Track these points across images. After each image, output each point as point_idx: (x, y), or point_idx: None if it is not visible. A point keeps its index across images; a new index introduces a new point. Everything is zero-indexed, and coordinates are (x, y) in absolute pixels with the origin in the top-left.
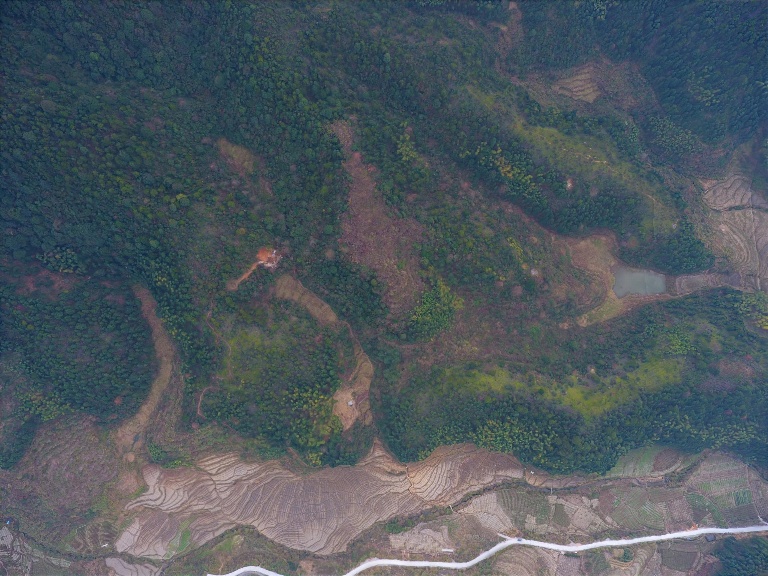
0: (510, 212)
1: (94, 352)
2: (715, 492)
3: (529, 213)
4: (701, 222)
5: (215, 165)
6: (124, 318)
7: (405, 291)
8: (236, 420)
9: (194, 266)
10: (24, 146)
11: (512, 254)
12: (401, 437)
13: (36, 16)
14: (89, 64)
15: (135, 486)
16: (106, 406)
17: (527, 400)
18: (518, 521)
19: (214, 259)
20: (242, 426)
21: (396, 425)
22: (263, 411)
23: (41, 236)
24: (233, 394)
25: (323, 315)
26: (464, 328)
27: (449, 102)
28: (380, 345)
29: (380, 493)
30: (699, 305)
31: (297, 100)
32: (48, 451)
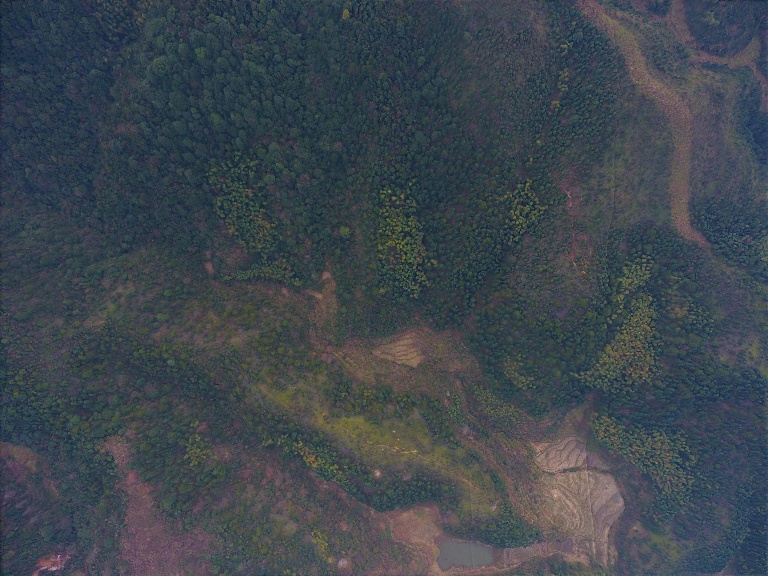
0: (325, 488)
1: None
2: None
3: None
4: (529, 492)
5: None
6: None
7: None
8: None
9: None
10: None
11: (314, 551)
12: None
13: None
14: None
15: None
16: None
17: None
18: None
19: None
20: None
21: None
22: None
23: None
24: None
25: None
26: None
27: (245, 396)
28: None
29: None
30: None
31: (67, 419)
32: None
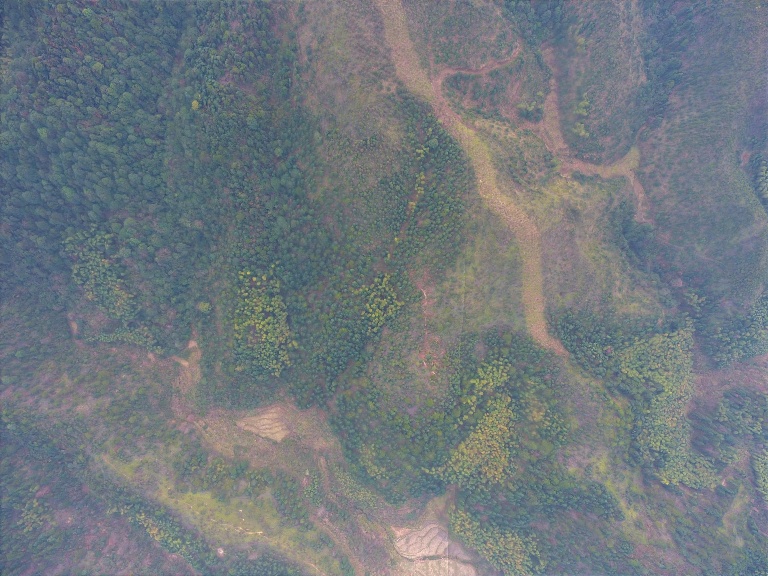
0: (173, 558)
1: None
2: None
3: None
4: None
5: None
6: None
7: None
8: None
9: None
10: None
11: None
12: None
13: None
14: None
15: None
16: None
17: None
18: None
19: None
20: None
21: None
22: None
23: None
24: None
25: None
26: None
27: None
28: None
29: None
30: None
31: None
32: None
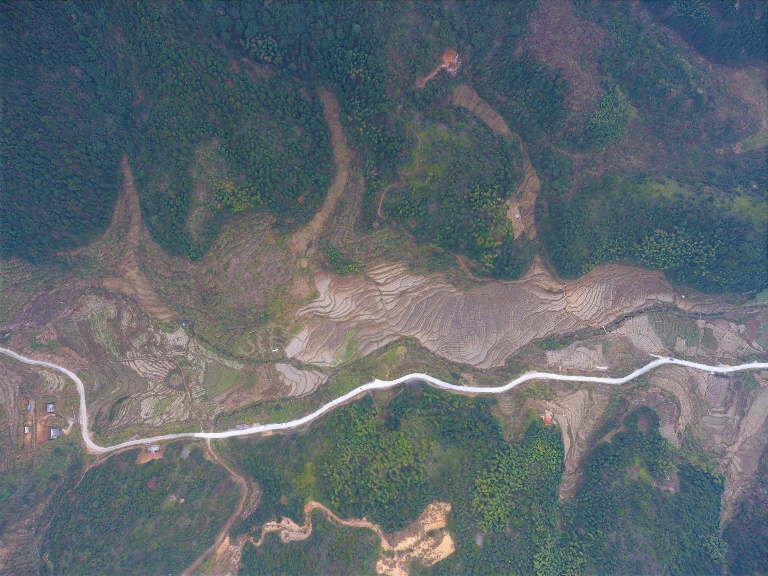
0: (671, 38)
1: (288, 142)
2: None
3: (690, 39)
4: None
5: None
6: (311, 116)
7: (586, 93)
8: (412, 223)
9: (391, 56)
10: None
11: (683, 68)
12: (569, 246)
13: None
14: None
15: (307, 292)
16: (289, 205)
17: (696, 207)
18: (669, 343)
19: (411, 49)
20: (419, 228)
21: (566, 232)
22: (445, 208)
23: (246, 20)
24: (418, 190)
25: (496, 126)
26: (629, 145)
27: None
28: (554, 153)
29: (538, 311)
30: None
31: None
32: (230, 249)
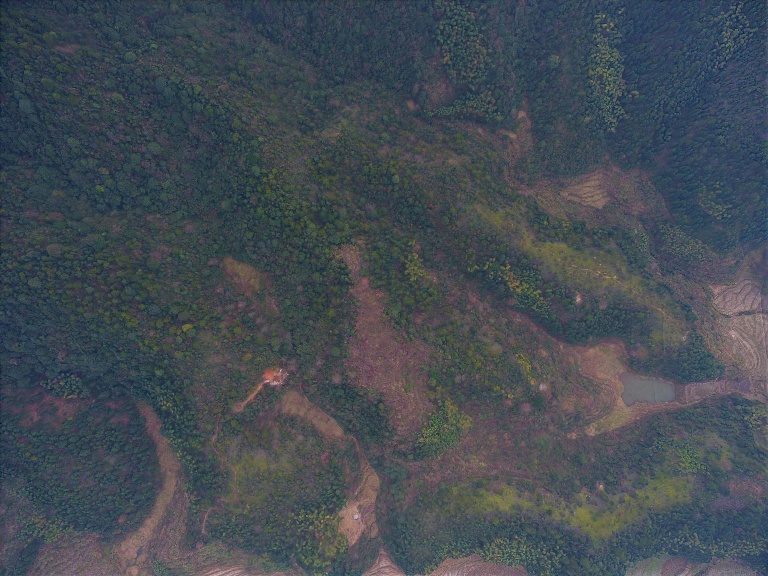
0: (518, 321)
1: (98, 476)
2: None
3: (537, 323)
4: (711, 330)
5: (221, 288)
6: (128, 438)
7: (412, 413)
8: (241, 538)
9: (200, 393)
10: (29, 291)
11: (520, 371)
12: (407, 553)
13: (42, 154)
14: (95, 196)
15: None
16: (110, 524)
17: (535, 520)
18: None
19: (220, 386)
20: (247, 544)
21: (402, 543)
22: (268, 533)
23: (45, 364)
24: (238, 517)
25: (329, 430)
26: (471, 442)
27: (458, 219)
28: (387, 463)
29: None
30: (709, 417)
31: (305, 226)
32: (51, 568)
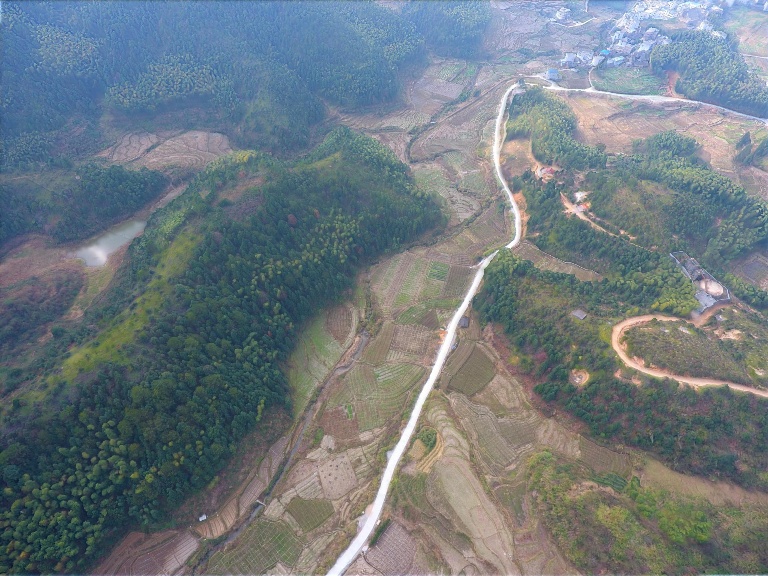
0: None
1: None
2: (416, 293)
3: None
4: None
5: None
6: None
7: None
8: None
9: None
10: None
11: None
12: None
13: None
14: None
15: None
16: None
17: (4, 436)
18: None
19: None
20: None
21: None
22: None
23: None
24: None
25: None
26: None
27: None
28: None
29: None
30: None
31: None
32: None
